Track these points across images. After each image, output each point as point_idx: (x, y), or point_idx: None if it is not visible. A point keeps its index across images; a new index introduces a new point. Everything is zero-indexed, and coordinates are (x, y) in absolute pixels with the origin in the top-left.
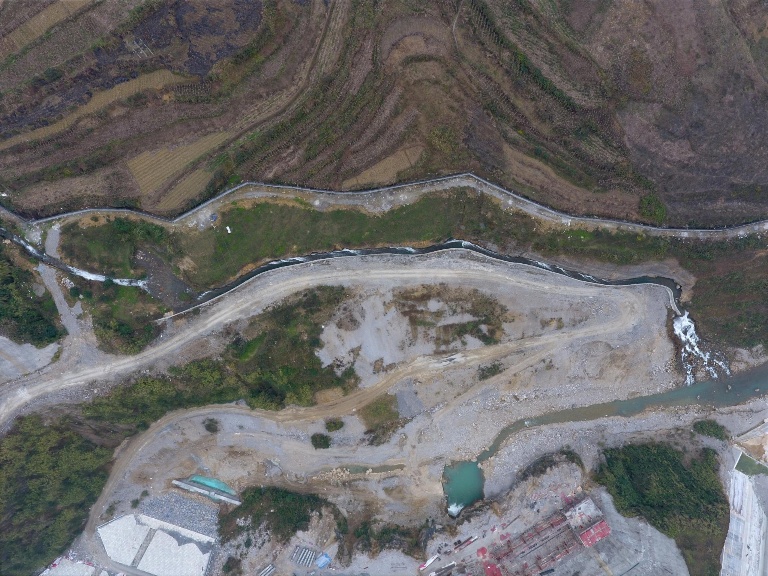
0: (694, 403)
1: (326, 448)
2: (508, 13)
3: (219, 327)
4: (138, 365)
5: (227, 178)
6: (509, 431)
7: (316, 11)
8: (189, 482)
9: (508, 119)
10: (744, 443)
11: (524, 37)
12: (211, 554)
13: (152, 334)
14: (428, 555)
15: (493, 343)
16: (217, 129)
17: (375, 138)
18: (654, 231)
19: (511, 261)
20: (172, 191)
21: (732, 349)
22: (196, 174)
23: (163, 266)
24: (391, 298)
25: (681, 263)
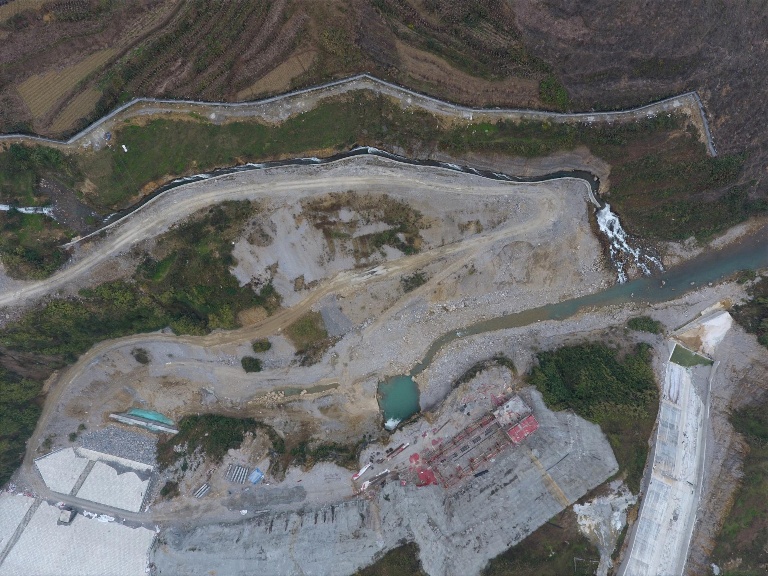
0: (628, 301)
1: (258, 371)
2: None
3: (127, 248)
4: (48, 289)
5: (117, 96)
6: (441, 343)
7: None
8: (127, 415)
9: (396, 13)
10: (680, 336)
11: None
12: (150, 481)
13: (61, 259)
14: (361, 465)
15: (413, 252)
16: (102, 47)
17: (265, 45)
18: (559, 118)
19: (420, 164)
20: (63, 112)
21: (663, 243)
22: (86, 94)
23: (67, 192)
24: (300, 210)
25: (592, 150)
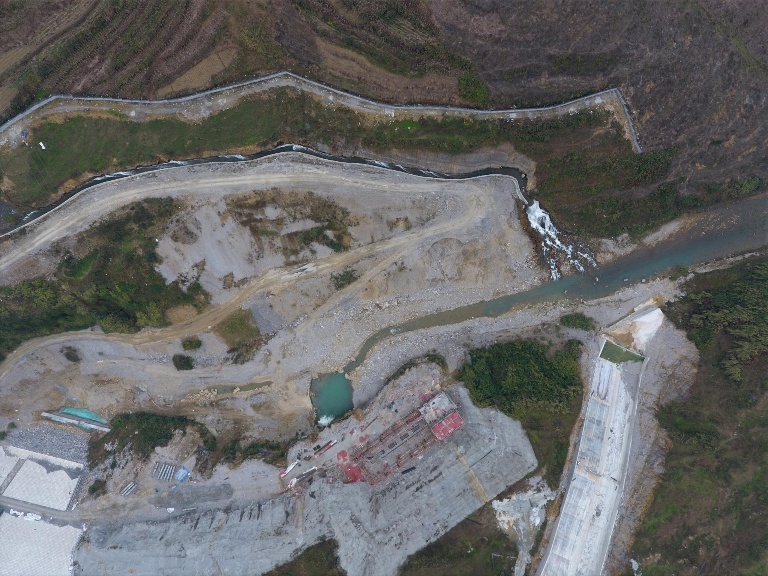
0: (562, 298)
1: (190, 369)
2: None
3: (47, 245)
4: None
5: (34, 93)
6: (375, 340)
7: None
8: (59, 414)
9: (314, 10)
10: (612, 332)
11: None
12: (80, 479)
13: None
14: (288, 462)
15: (343, 250)
16: (17, 44)
17: (184, 43)
18: (481, 115)
19: (346, 161)
20: None
21: (596, 240)
22: (1, 91)
23: None
24: (225, 207)
25: (516, 147)
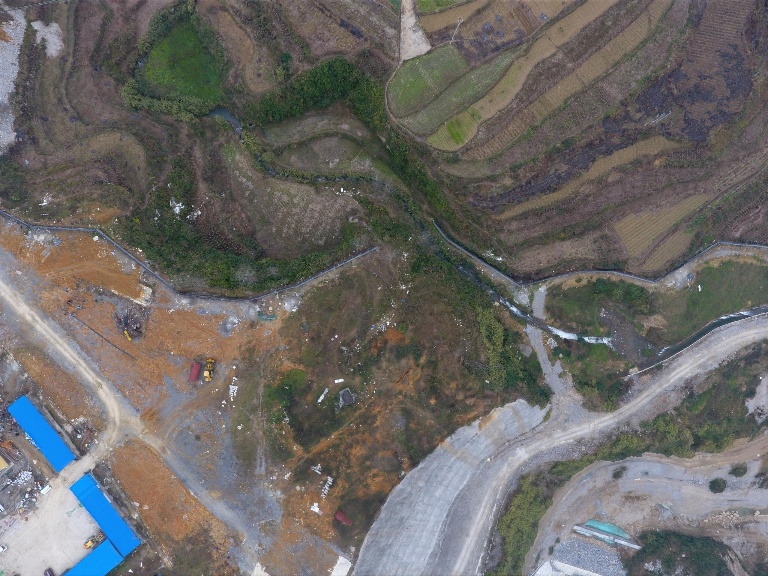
0: None
1: (721, 492)
2: None
3: (681, 382)
4: (616, 422)
5: (703, 239)
6: None
7: None
8: (586, 527)
9: None
10: None
11: None
12: None
13: (620, 390)
14: None
15: None
16: (697, 191)
17: None
18: None
19: None
20: (655, 252)
21: None
22: (677, 235)
23: (625, 323)
24: None
25: None
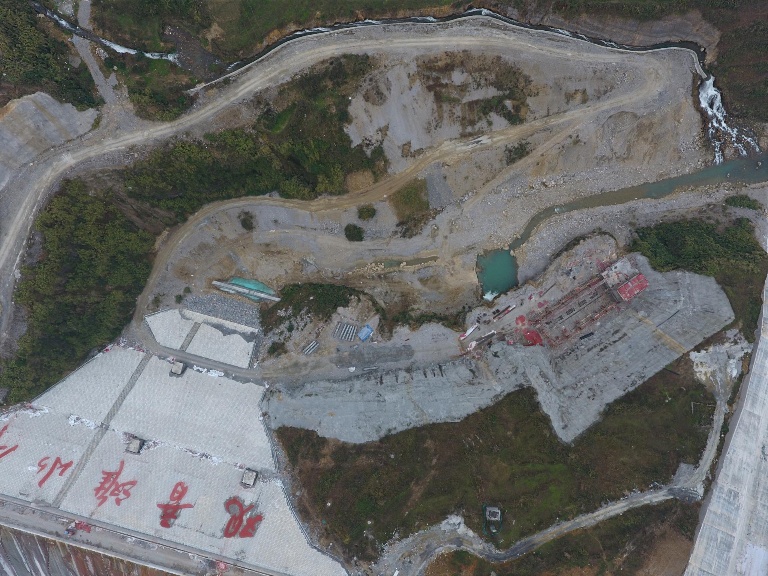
0: (724, 181)
1: (360, 241)
2: None
3: (250, 95)
4: (175, 131)
5: None
6: (539, 219)
7: None
8: (229, 283)
9: None
10: None
11: None
12: (255, 342)
13: (186, 105)
14: (467, 326)
15: (519, 122)
16: None
17: None
18: None
19: (532, 28)
20: None
21: (760, 124)
22: None
23: (191, 40)
24: (415, 69)
25: (704, 14)
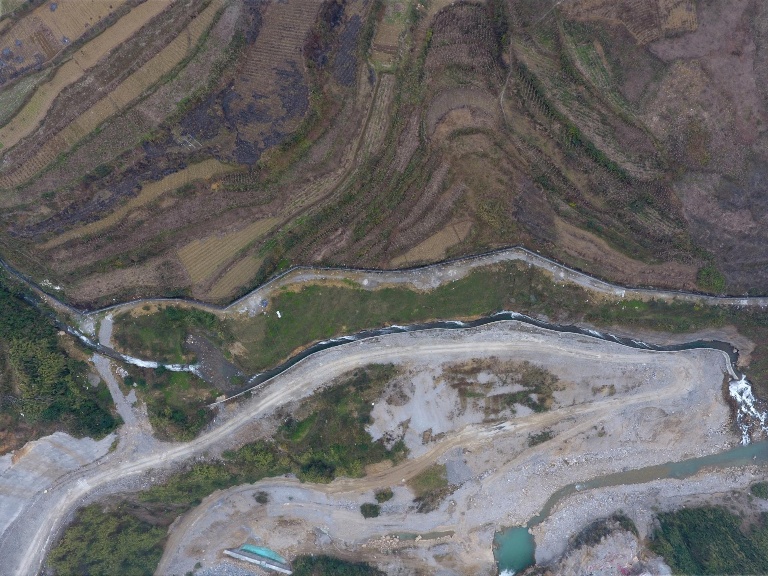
0: (750, 464)
1: (375, 517)
2: (558, 85)
3: (271, 410)
4: (193, 452)
5: (276, 263)
6: (559, 495)
7: (362, 91)
8: (240, 551)
9: (560, 193)
10: None
11: (575, 108)
12: None
13: (205, 419)
14: None
15: (543, 410)
16: (265, 215)
17: (423, 215)
18: (712, 300)
19: (562, 331)
20: (222, 279)
21: None
22: (246, 261)
23: (214, 350)
24: (441, 372)
25: (740, 330)
